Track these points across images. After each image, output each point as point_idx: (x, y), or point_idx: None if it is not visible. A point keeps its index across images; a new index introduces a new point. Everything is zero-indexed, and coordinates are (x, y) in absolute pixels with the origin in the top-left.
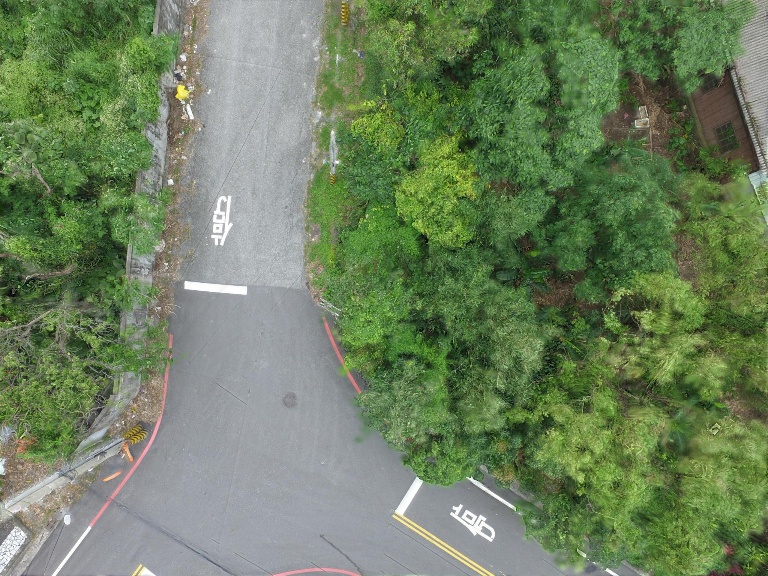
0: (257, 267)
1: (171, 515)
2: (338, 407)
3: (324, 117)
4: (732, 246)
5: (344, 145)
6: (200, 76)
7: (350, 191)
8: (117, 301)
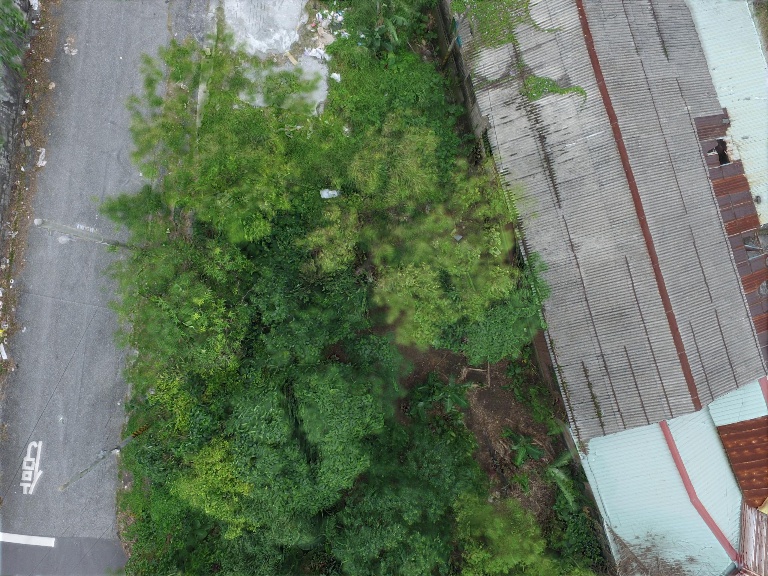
0: (66, 517)
1: None
2: None
3: (141, 356)
4: None
5: None
6: (15, 313)
7: None
8: None
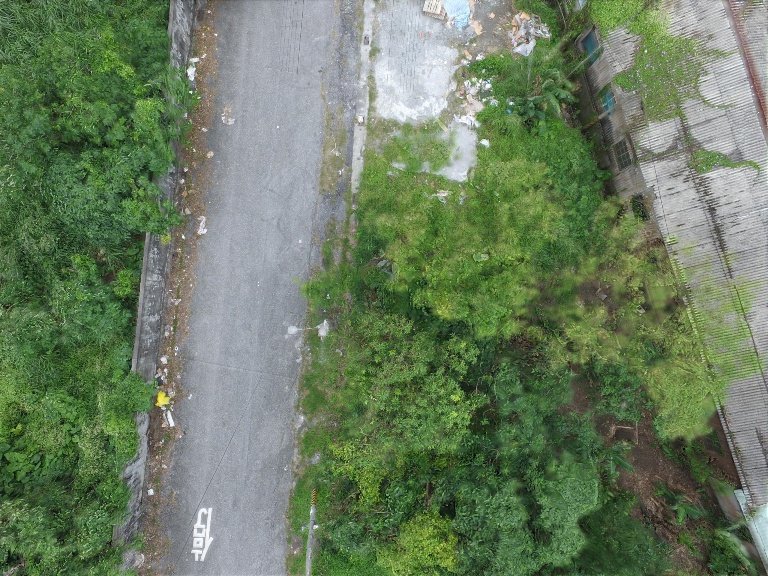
0: None
1: None
2: None
3: (306, 422)
4: None
5: (326, 450)
6: (181, 380)
7: (332, 499)
8: None
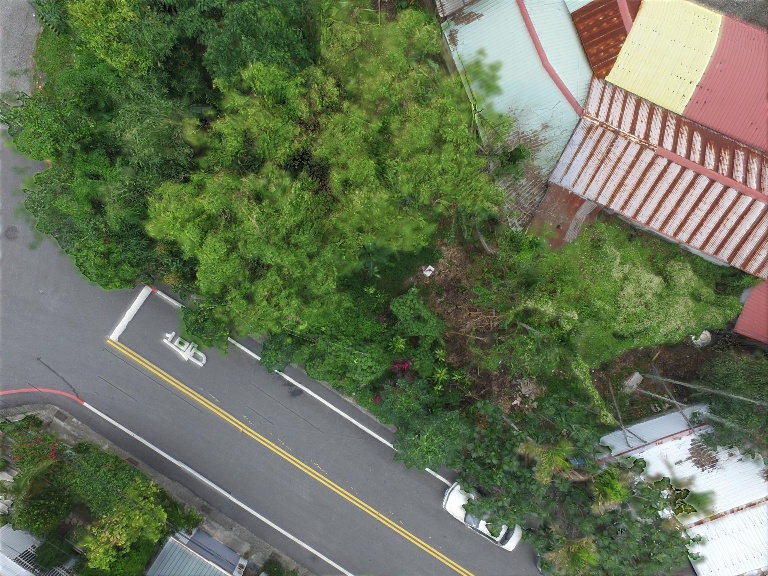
0: None
1: None
2: None
3: None
4: (325, 38)
5: None
6: None
7: None
8: None
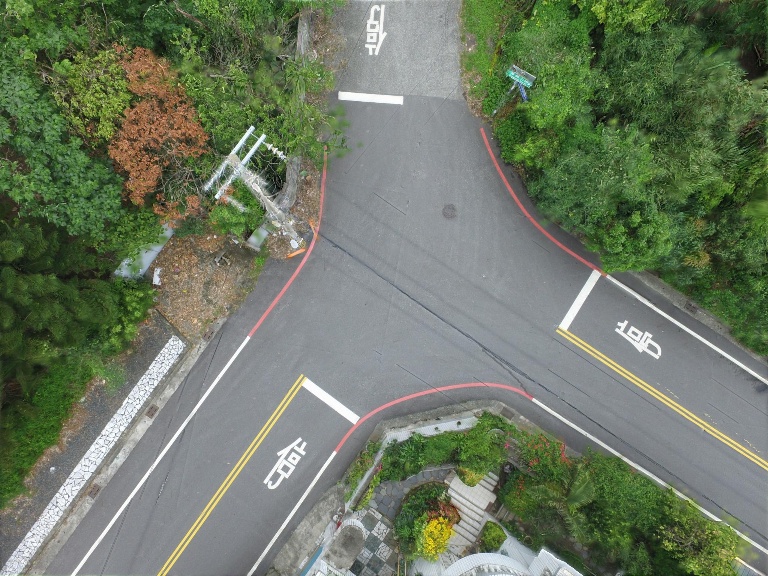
0: (413, 76)
1: (331, 325)
2: (498, 220)
3: None
4: None
5: None
6: None
7: (506, 1)
8: (292, 83)
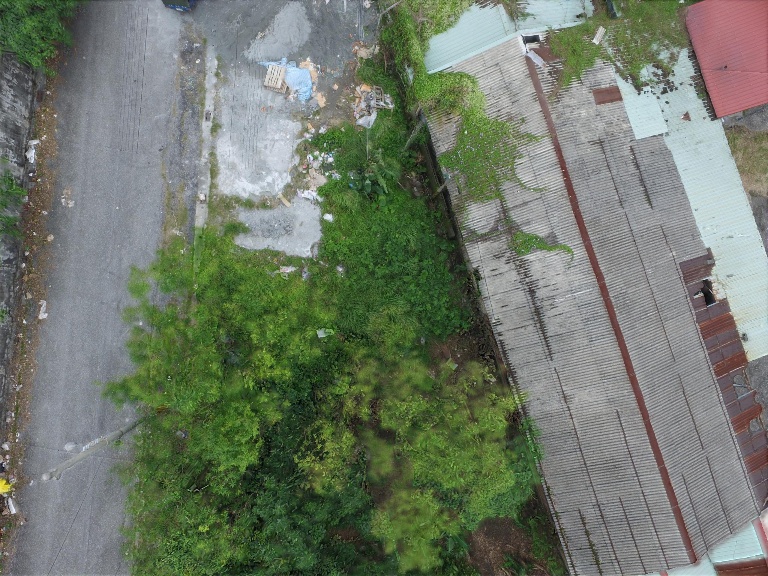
0: None
1: None
2: None
3: (147, 505)
4: None
5: (168, 533)
6: (22, 467)
7: None
8: None
